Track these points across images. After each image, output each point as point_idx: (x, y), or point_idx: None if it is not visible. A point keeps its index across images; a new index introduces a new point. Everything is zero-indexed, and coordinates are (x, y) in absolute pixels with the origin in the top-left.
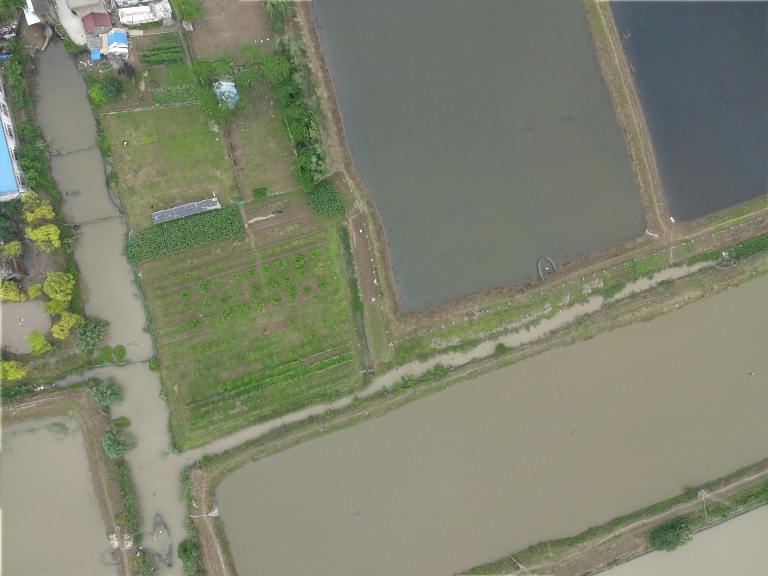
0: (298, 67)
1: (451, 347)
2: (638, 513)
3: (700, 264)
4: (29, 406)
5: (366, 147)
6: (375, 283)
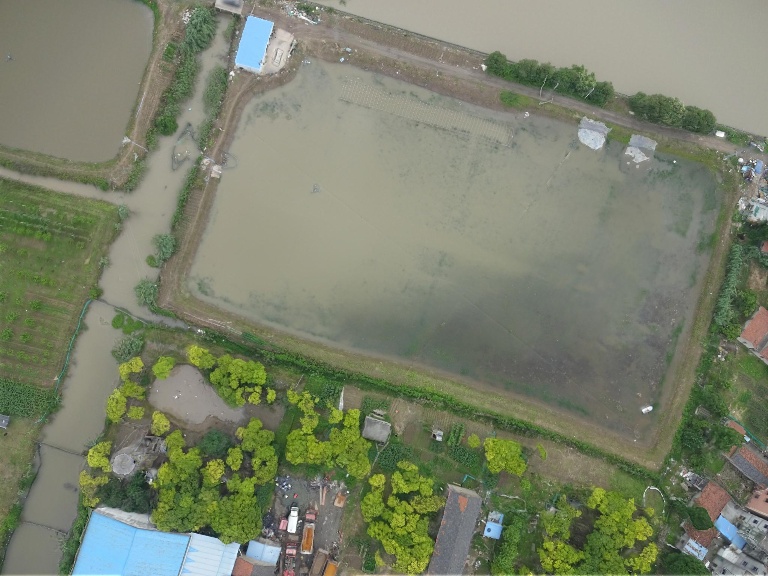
0: None
1: None
2: None
3: None
4: (214, 321)
5: None
6: None
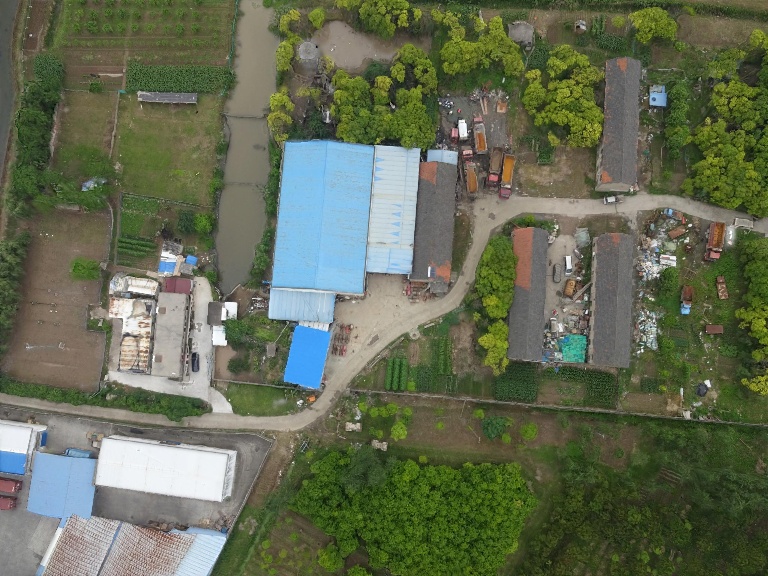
0: None
1: None
2: None
3: None
4: None
5: None
6: None
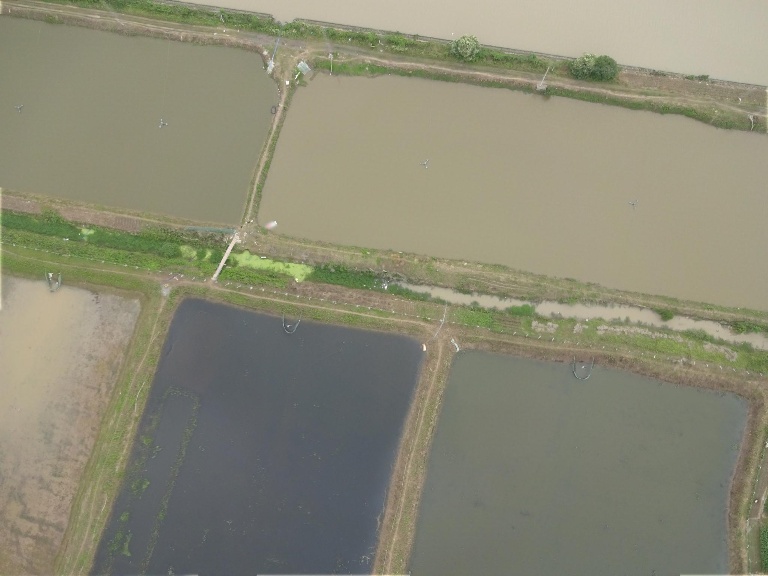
0: None
1: (714, 343)
2: (611, 102)
3: (416, 290)
4: None
5: None
6: None
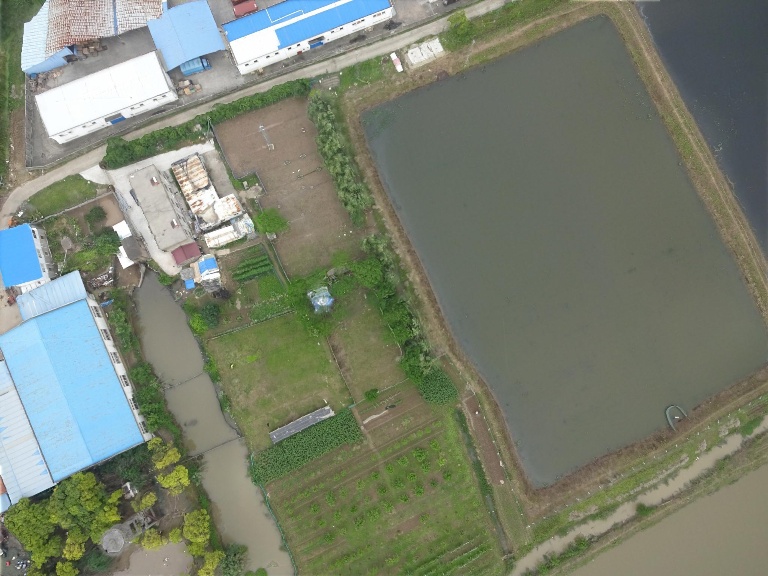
0: (388, 262)
1: (589, 516)
2: None
3: None
4: None
5: (467, 323)
6: (501, 465)
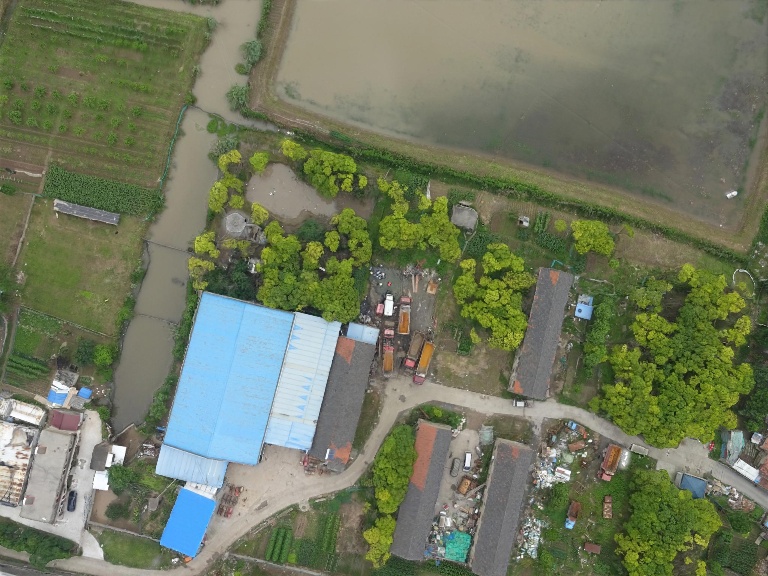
0: None
1: None
2: None
3: None
4: (302, 121)
5: None
6: None
